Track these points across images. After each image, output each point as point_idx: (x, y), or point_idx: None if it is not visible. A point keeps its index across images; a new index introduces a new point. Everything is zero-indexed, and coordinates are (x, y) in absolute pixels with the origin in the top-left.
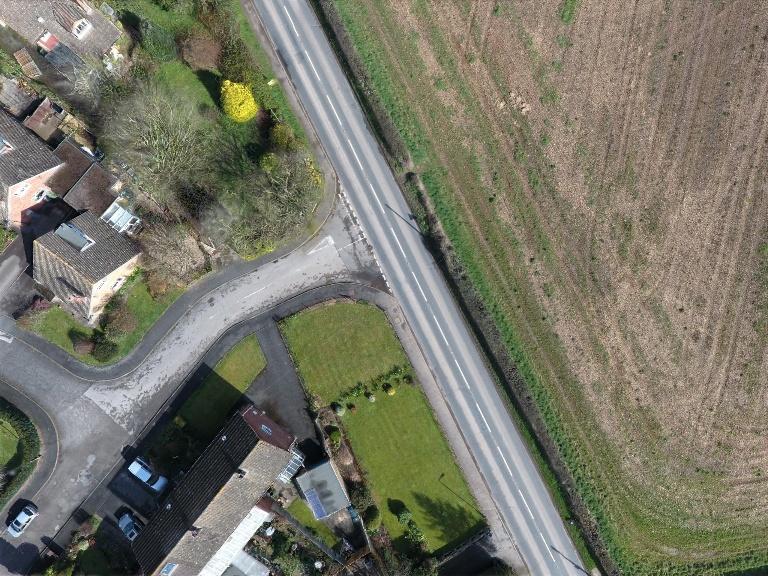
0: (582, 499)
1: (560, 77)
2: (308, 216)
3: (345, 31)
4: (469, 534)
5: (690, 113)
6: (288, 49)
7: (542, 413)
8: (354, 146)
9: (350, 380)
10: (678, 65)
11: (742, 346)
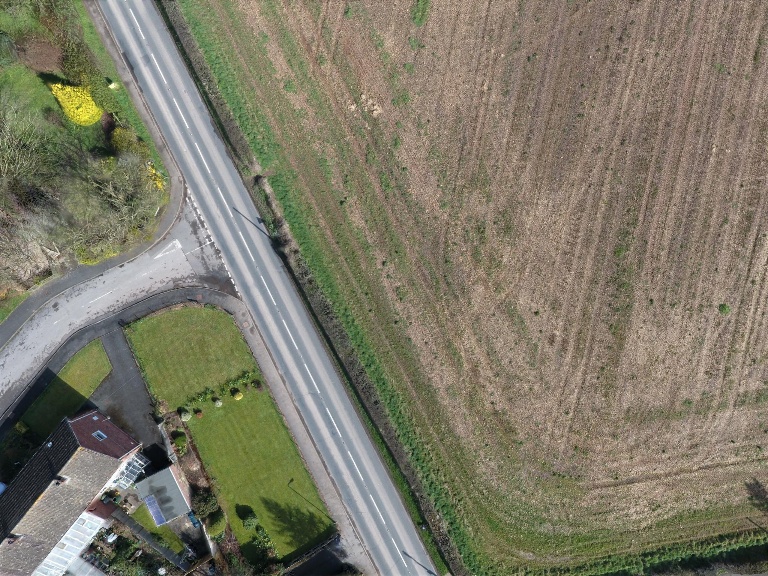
0: (435, 504)
1: (412, 79)
2: (151, 220)
3: (188, 34)
4: (319, 539)
5: (544, 115)
6: (134, 52)
7: (394, 417)
8: (201, 149)
9: (197, 385)
10: (532, 67)
11: (599, 349)
